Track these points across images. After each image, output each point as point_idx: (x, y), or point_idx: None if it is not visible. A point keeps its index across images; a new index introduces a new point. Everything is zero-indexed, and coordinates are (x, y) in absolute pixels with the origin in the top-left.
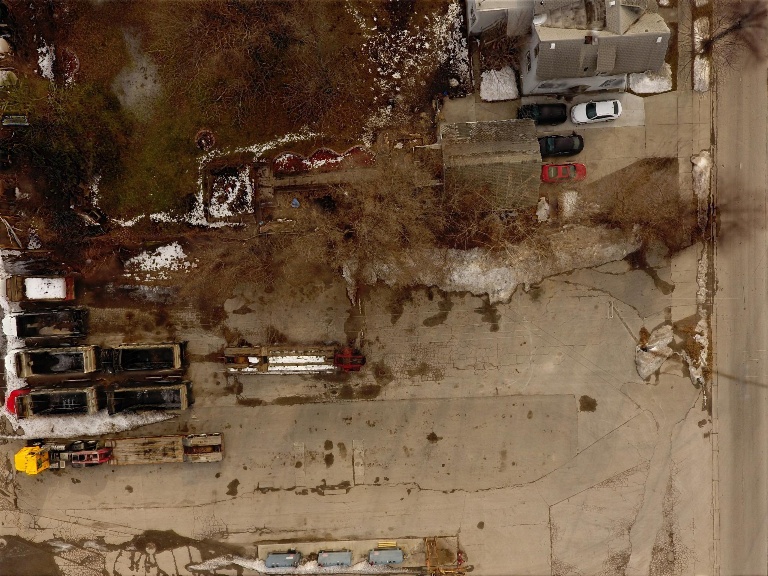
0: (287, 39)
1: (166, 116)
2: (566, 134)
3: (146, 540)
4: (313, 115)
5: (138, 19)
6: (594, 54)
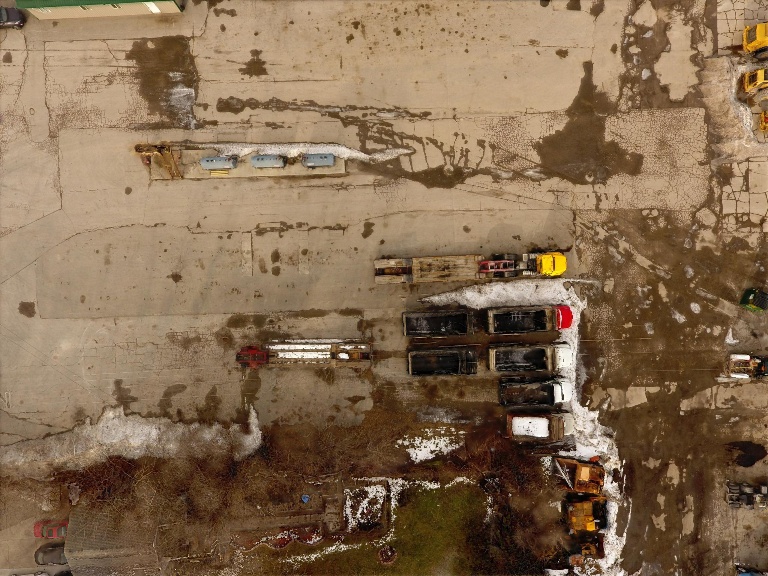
0: None
1: (423, 575)
2: None
3: (453, 178)
4: None
5: None
6: None
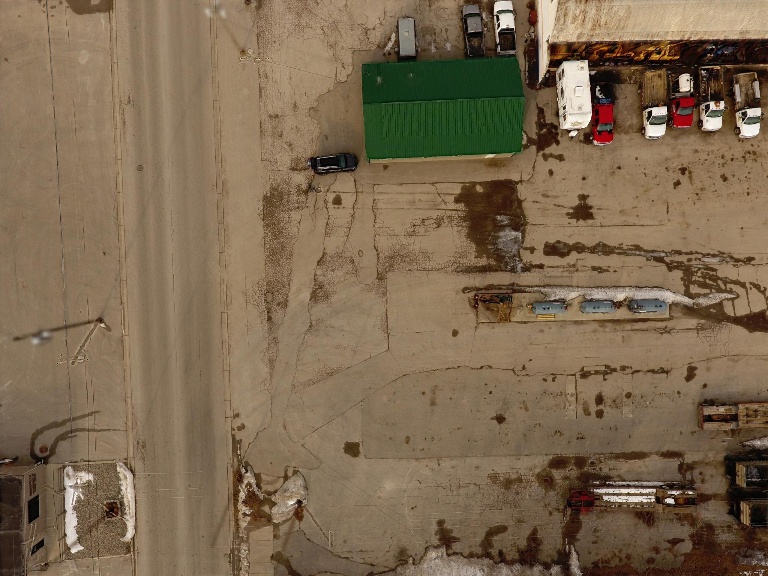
0: None
1: None
2: None
3: None
4: None
5: None
6: None
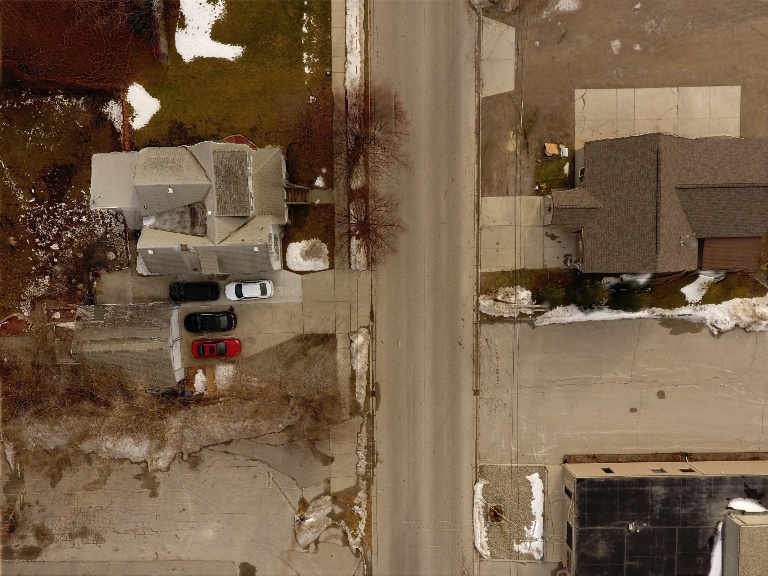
0: None
1: None
2: (223, 309)
3: None
4: None
5: None
6: (197, 258)
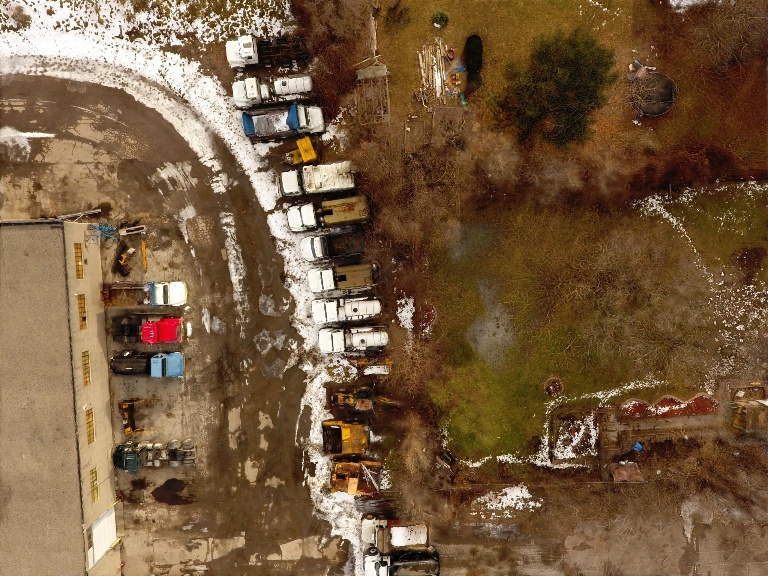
0: (637, 292)
1: (516, 363)
2: None
3: None
4: (658, 364)
5: (494, 272)
6: None
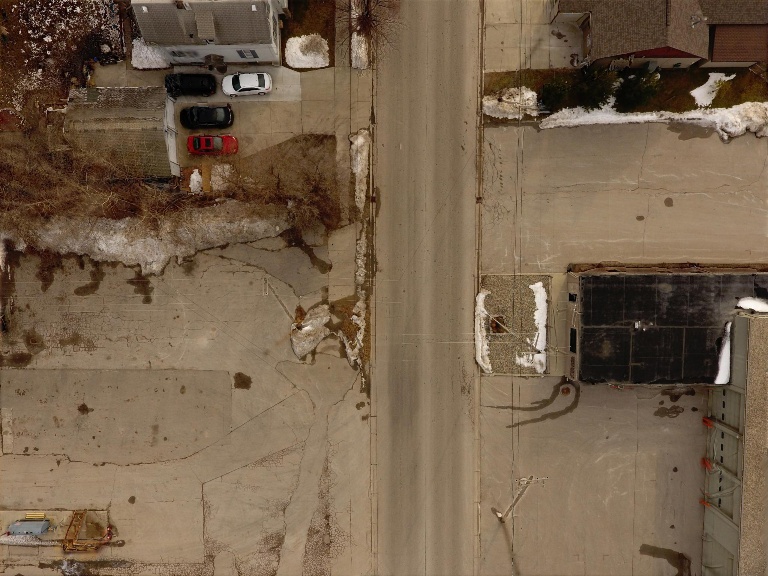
0: None
1: None
2: (220, 106)
3: None
4: None
5: None
6: (193, 20)
